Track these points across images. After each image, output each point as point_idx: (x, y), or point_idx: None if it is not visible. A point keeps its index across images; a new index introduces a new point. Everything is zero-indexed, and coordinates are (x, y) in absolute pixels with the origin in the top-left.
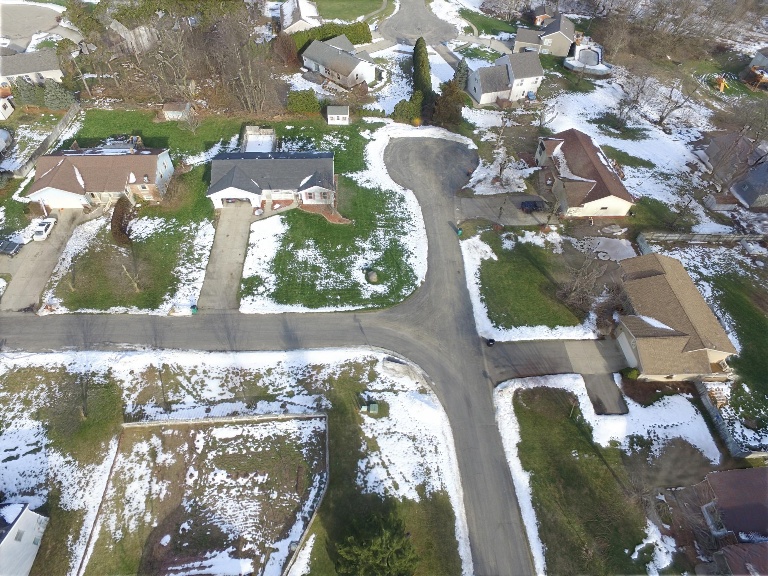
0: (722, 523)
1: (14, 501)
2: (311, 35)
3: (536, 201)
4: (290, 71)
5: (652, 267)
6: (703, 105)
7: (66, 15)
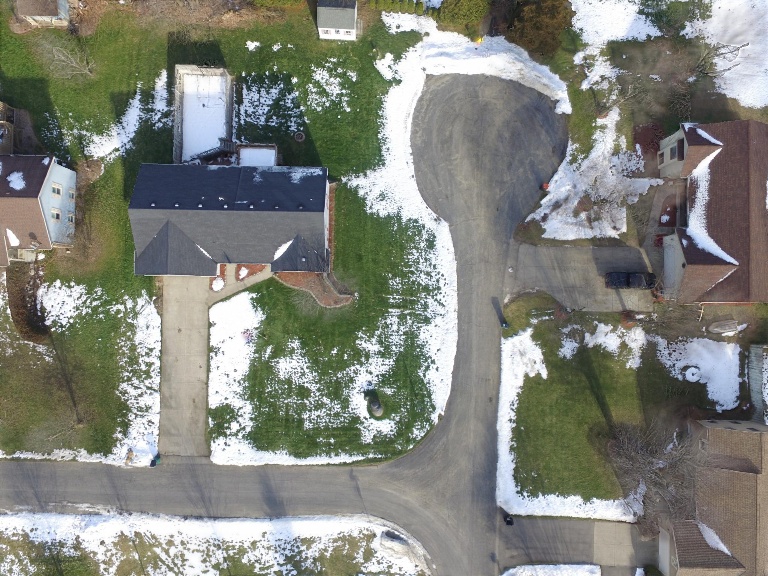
0: None
1: None
2: None
3: (631, 277)
4: None
5: (748, 456)
6: None
7: None
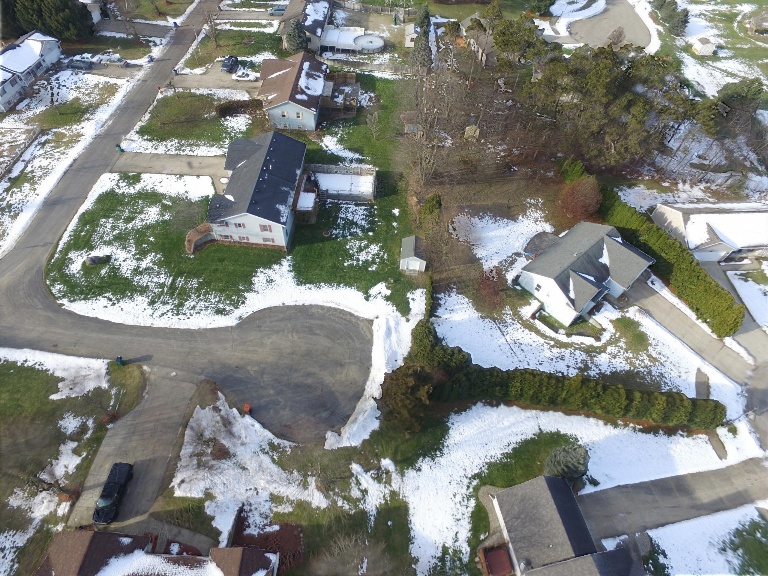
0: None
1: (27, 101)
2: (643, 228)
3: (114, 484)
4: (556, 219)
5: None
6: None
7: None
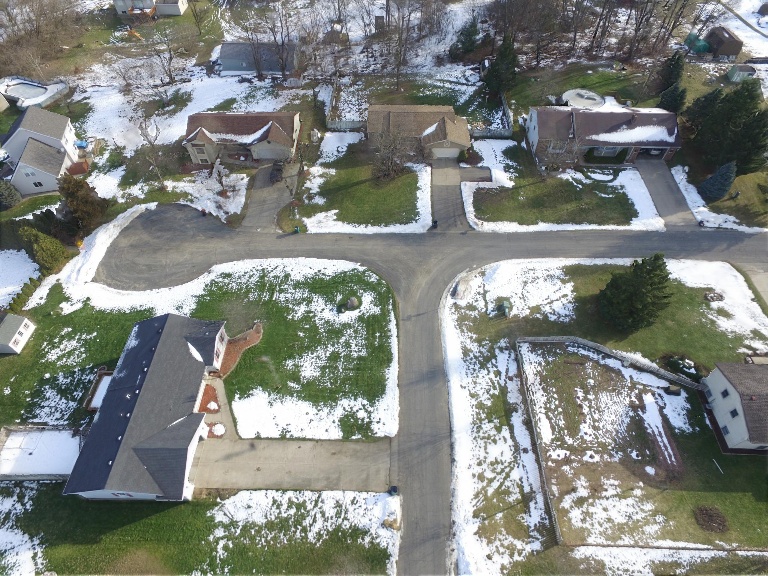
0: (564, 142)
1: None
2: None
3: (274, 168)
4: None
5: (381, 116)
6: (156, 54)
7: None
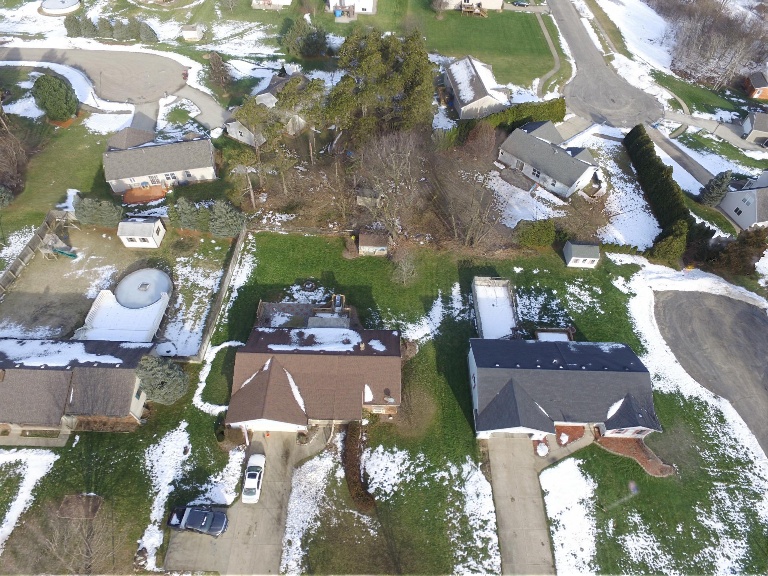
0: None
1: None
2: (504, 118)
3: None
4: (483, 167)
5: None
6: None
7: (243, 114)
